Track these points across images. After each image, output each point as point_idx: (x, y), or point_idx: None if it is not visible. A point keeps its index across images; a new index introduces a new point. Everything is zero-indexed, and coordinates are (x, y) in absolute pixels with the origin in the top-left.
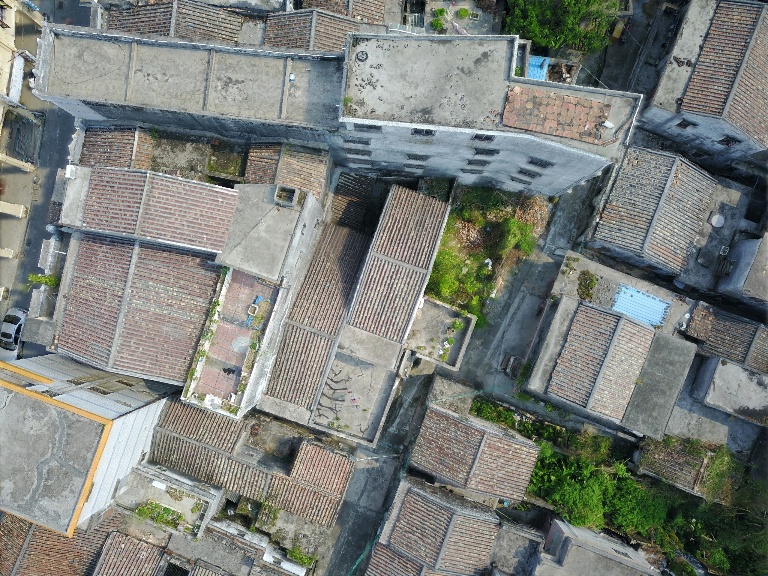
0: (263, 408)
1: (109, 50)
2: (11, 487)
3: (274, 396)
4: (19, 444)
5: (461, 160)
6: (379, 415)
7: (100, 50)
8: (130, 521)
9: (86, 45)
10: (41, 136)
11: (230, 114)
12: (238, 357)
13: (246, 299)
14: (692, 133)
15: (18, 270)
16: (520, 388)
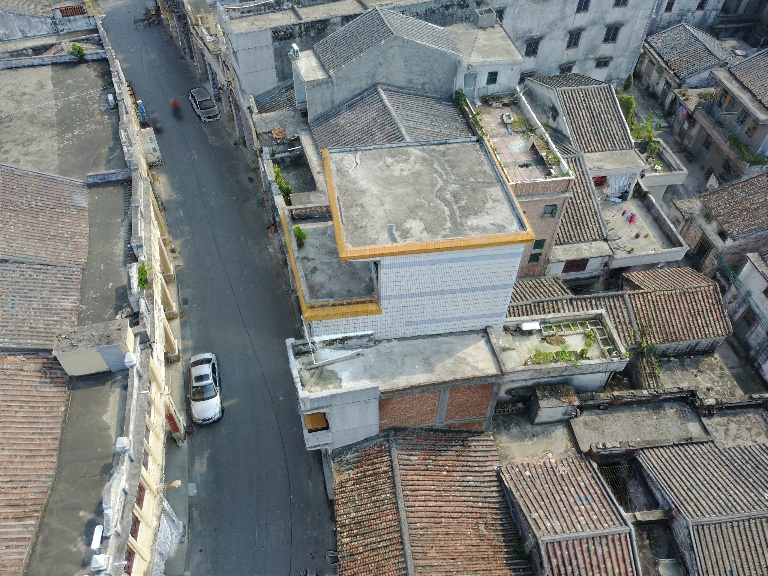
0: (559, 259)
1: (275, 16)
2: (420, 224)
3: (561, 242)
4: (398, 186)
5: (563, 38)
6: (662, 236)
7: (267, 18)
8: (508, 451)
9: (254, 19)
10: (165, 219)
11: (401, 4)
12: (524, 154)
13: (493, 120)
14: (677, 14)
15: (182, 330)
16: (749, 154)
